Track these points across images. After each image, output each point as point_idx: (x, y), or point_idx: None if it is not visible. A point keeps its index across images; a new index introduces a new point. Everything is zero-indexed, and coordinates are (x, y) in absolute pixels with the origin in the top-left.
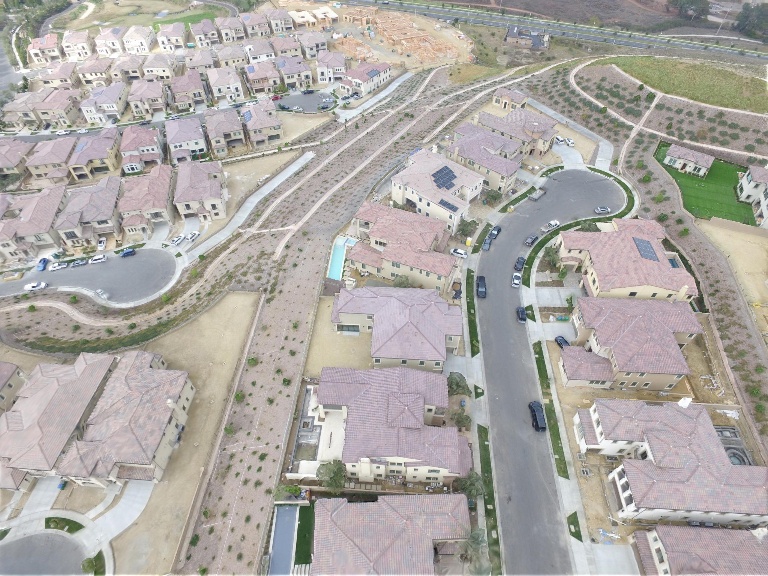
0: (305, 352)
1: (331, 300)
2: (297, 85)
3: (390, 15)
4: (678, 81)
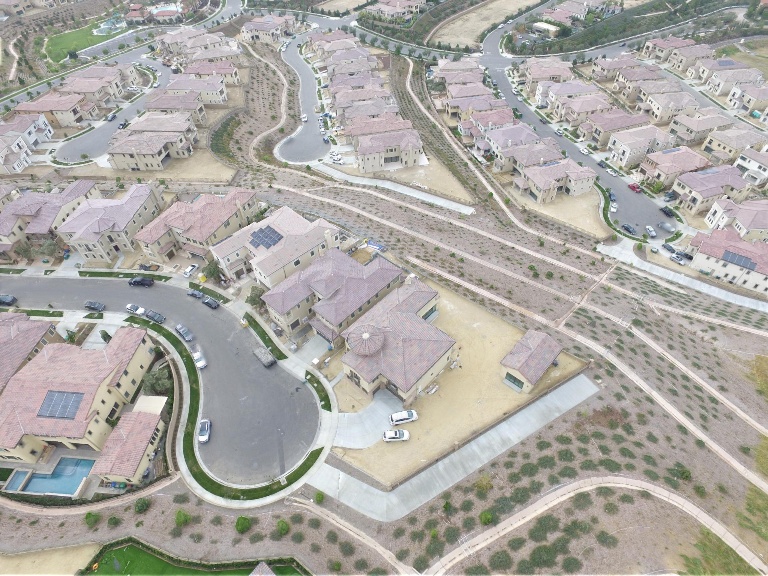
0: None
1: None
2: None
3: None
4: None
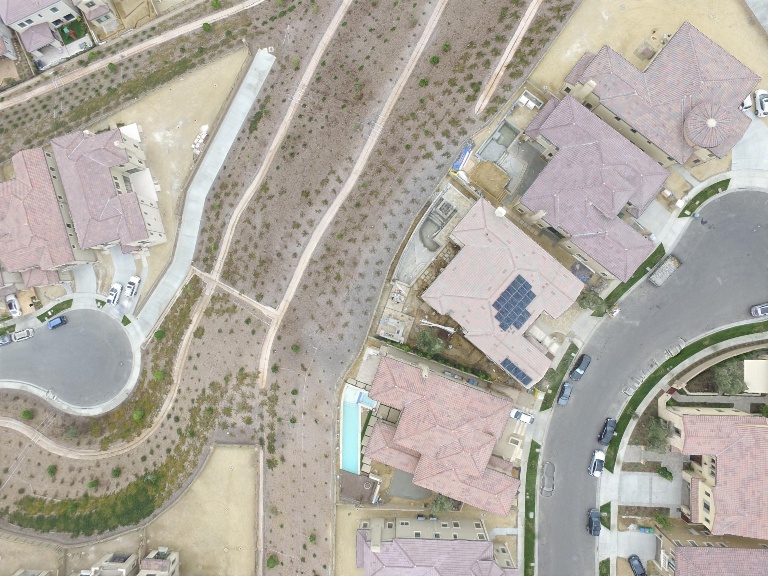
0: None
1: (351, 506)
2: None
3: None
4: None
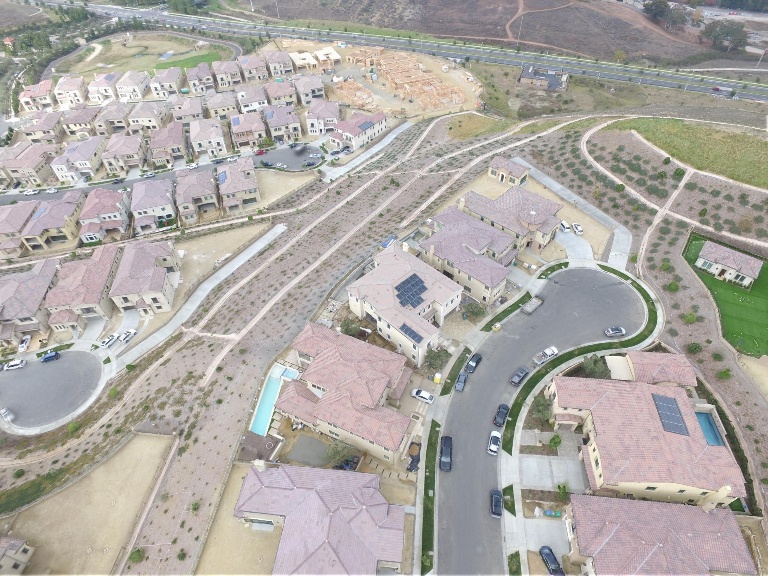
0: (196, 558)
1: (247, 468)
2: (285, 137)
3: (395, 56)
4: (713, 154)
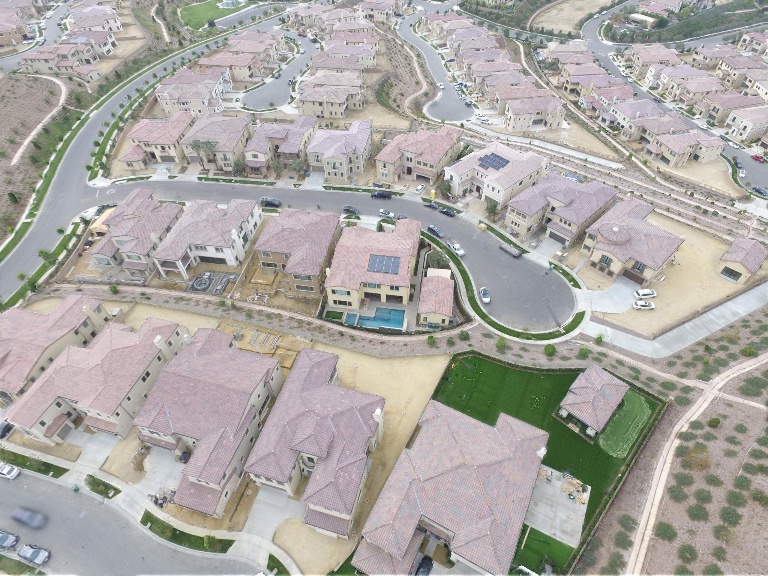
0: None
1: None
2: None
3: None
4: None
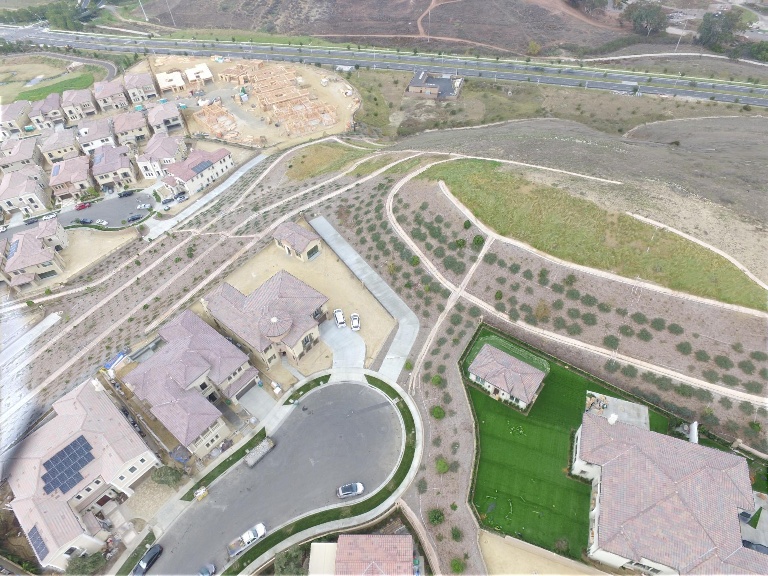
0: None
1: None
2: (116, 185)
3: (272, 70)
4: (518, 215)
